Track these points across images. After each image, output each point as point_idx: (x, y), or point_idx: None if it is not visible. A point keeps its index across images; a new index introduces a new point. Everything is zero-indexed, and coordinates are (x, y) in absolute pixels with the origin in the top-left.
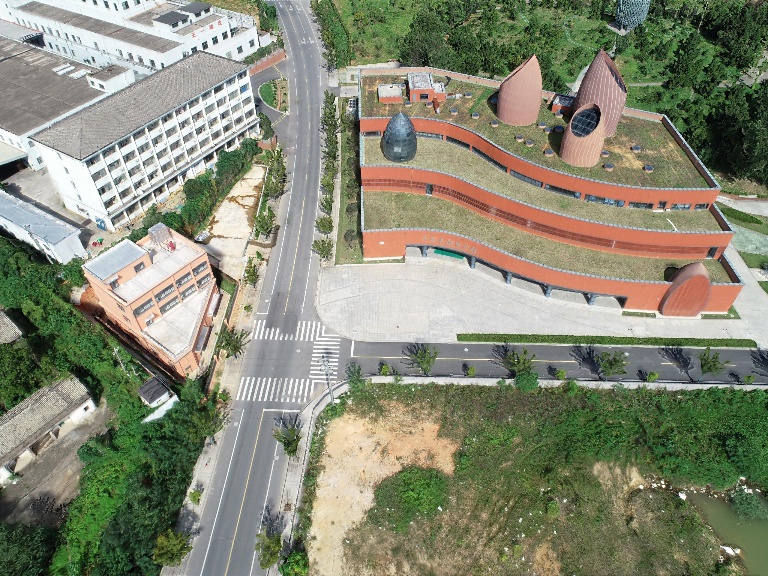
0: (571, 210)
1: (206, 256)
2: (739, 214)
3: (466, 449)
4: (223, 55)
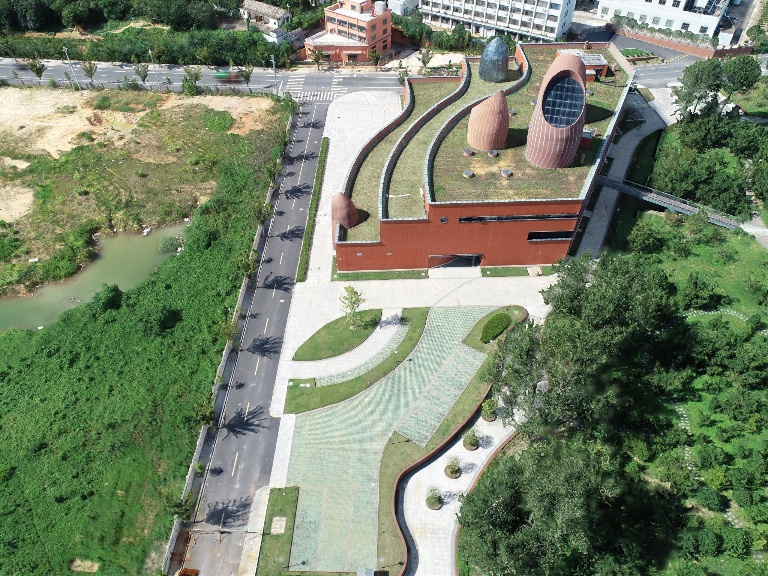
0: (420, 146)
1: (367, 25)
2: (496, 324)
3: (238, 136)
4: (663, 19)
